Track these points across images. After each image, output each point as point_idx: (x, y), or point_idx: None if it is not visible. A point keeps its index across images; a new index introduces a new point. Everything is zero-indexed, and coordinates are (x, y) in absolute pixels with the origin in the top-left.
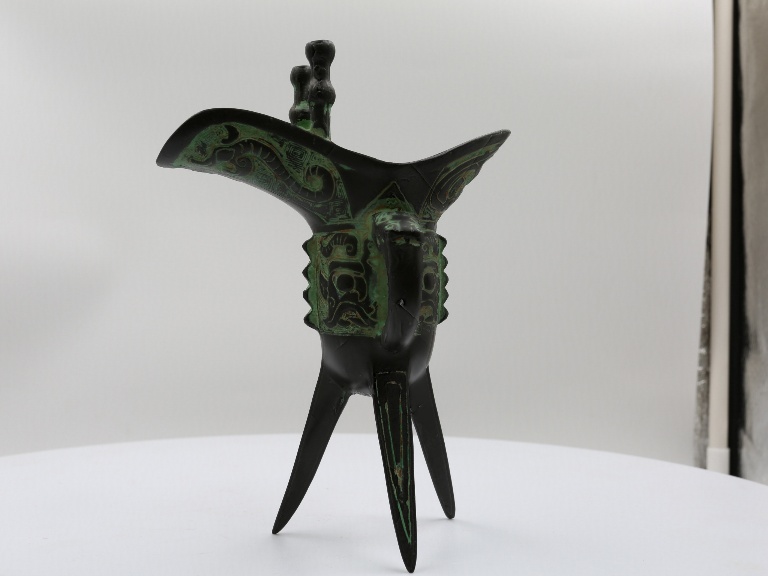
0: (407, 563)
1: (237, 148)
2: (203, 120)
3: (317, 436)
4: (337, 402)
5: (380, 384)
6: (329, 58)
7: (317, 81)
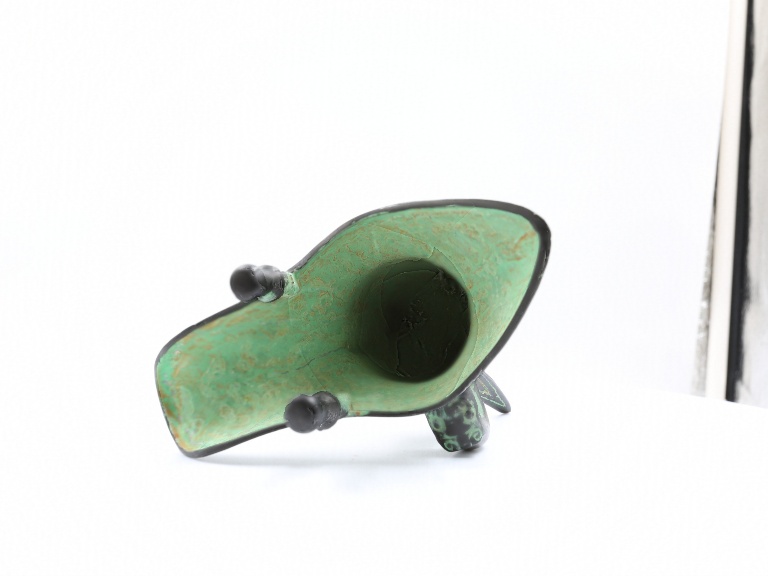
0: None
1: None
2: None
3: None
4: (406, 327)
5: None
6: None
7: None
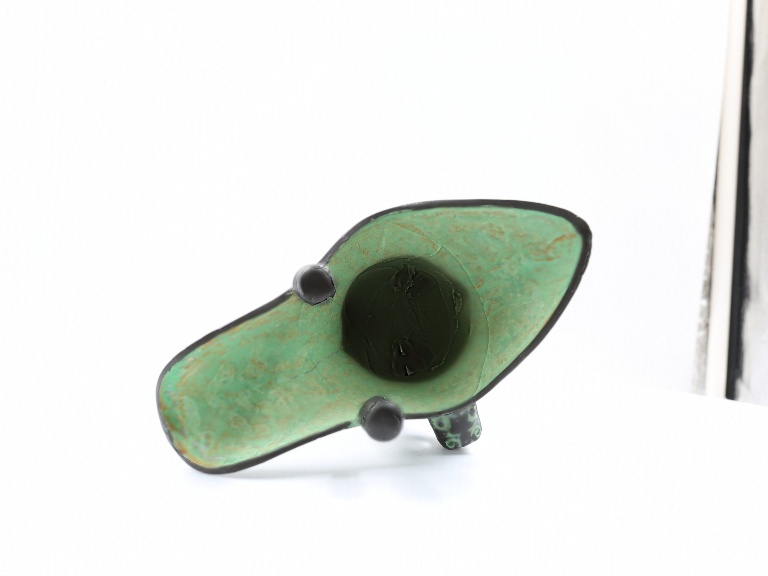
0: None
1: None
2: None
3: None
4: None
5: None
6: None
7: None
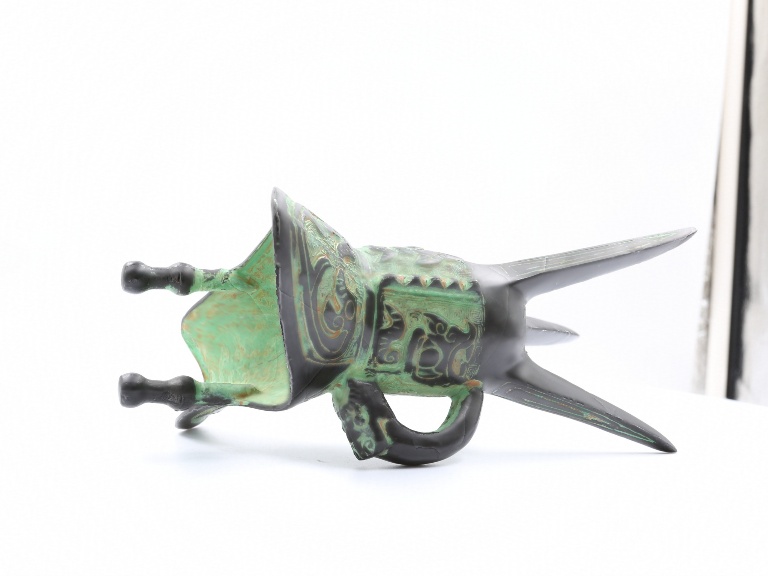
0: (666, 451)
1: None
2: (184, 426)
3: None
4: None
5: (503, 395)
6: (142, 397)
7: None
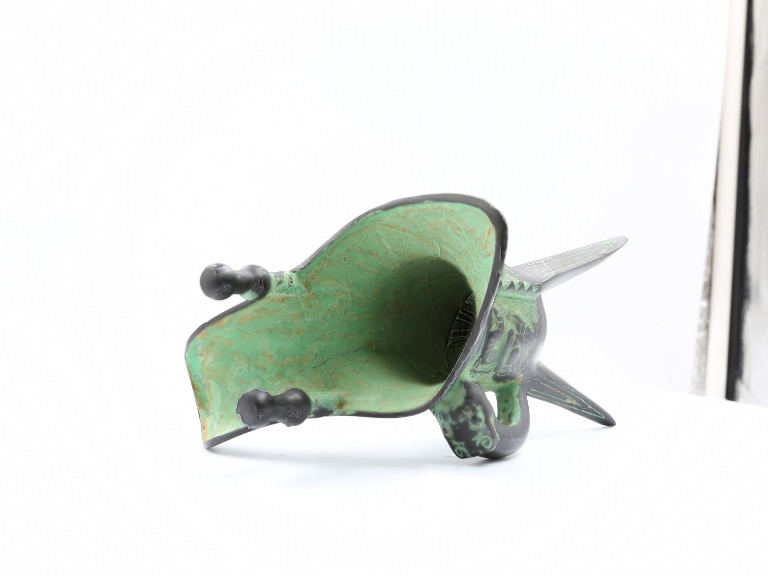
0: None
1: None
2: None
3: None
4: None
5: None
6: (272, 415)
7: (282, 422)
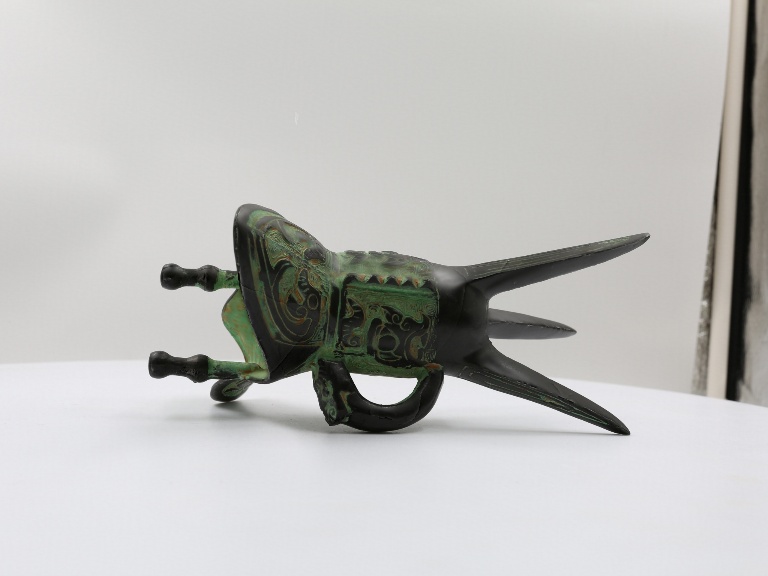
0: (621, 433)
1: (243, 386)
2: None
3: (505, 332)
4: None
5: (469, 379)
6: (165, 370)
7: None
